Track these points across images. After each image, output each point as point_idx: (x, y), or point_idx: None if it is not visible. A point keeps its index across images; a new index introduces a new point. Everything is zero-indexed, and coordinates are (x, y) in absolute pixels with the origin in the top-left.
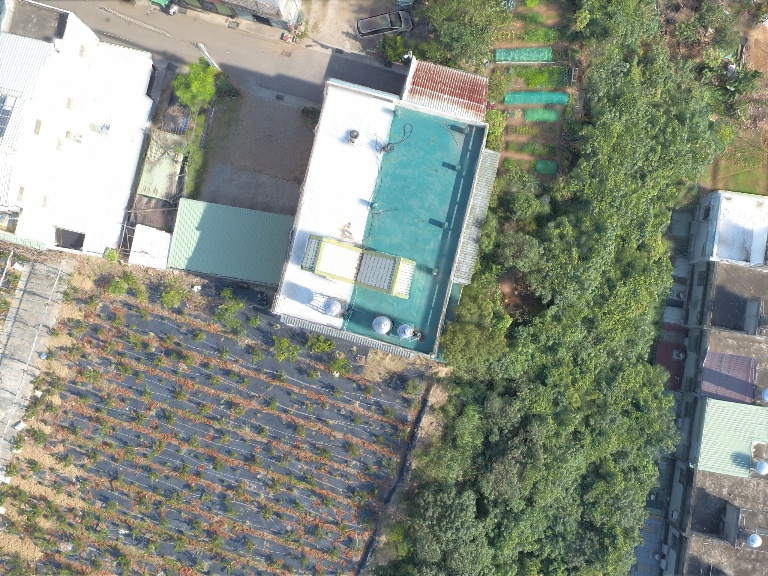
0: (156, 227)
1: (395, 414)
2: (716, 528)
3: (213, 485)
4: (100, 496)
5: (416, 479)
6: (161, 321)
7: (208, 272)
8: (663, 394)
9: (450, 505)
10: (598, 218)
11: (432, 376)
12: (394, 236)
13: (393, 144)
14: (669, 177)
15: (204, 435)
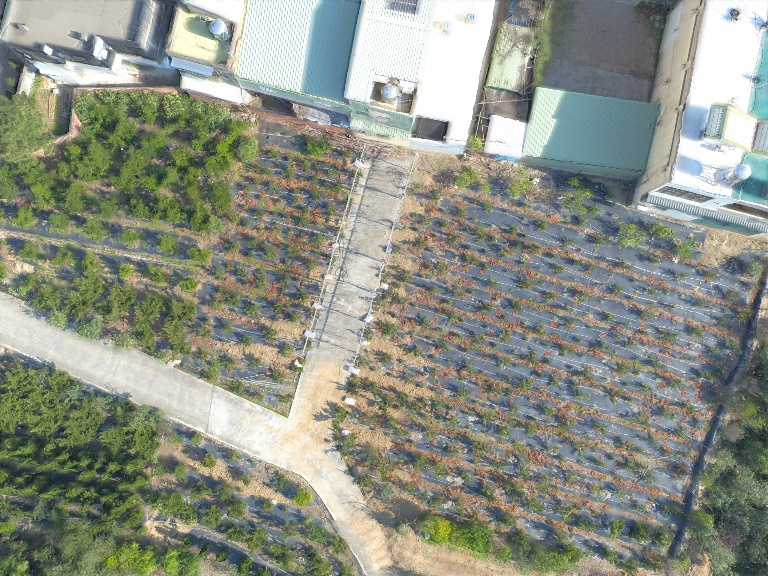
0: None
1: None
2: None
3: (558, 371)
4: (448, 385)
5: (756, 360)
6: (502, 213)
7: (563, 159)
8: None
9: None
10: None
11: None
12: None
13: None
14: None
15: (549, 323)
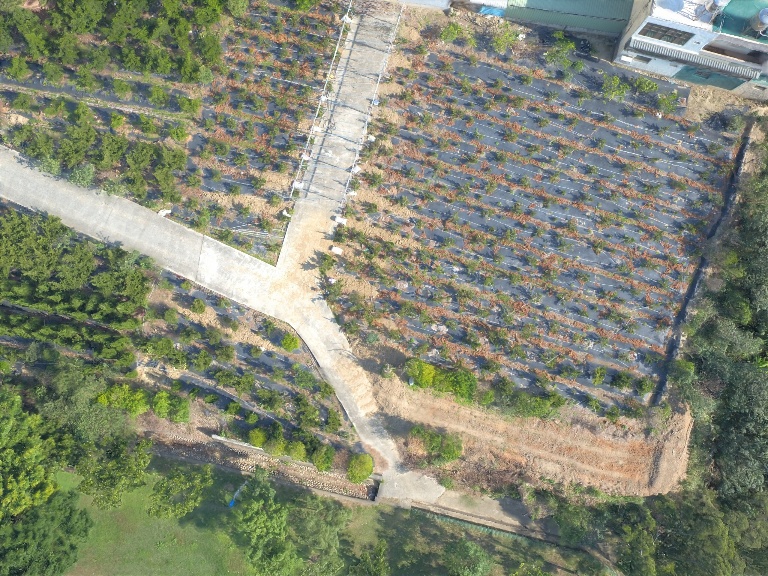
0: None
1: (717, 152)
2: None
3: (543, 224)
4: (434, 236)
5: (738, 214)
6: (489, 68)
7: (548, 9)
8: None
9: None
10: None
11: (751, 116)
12: None
13: None
14: None
15: (534, 175)
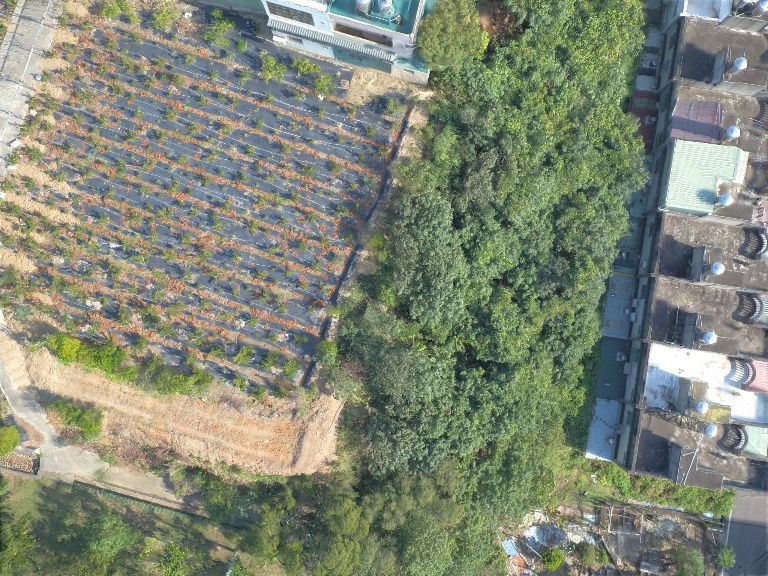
0: None
1: (377, 135)
2: (683, 273)
3: (201, 202)
4: (92, 212)
5: (396, 197)
6: (153, 45)
7: None
8: (634, 137)
9: (428, 208)
10: None
11: (413, 100)
12: None
13: None
14: None
15: (193, 154)
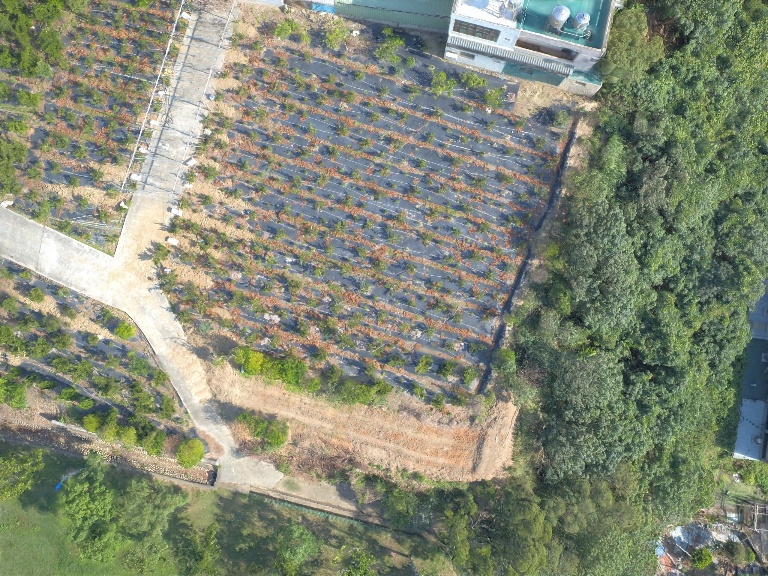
0: None
1: (545, 146)
2: None
3: (374, 216)
4: (268, 227)
5: (565, 207)
6: (323, 63)
7: (374, 6)
8: None
9: (605, 217)
10: None
11: (579, 111)
12: None
13: None
14: None
15: (365, 168)
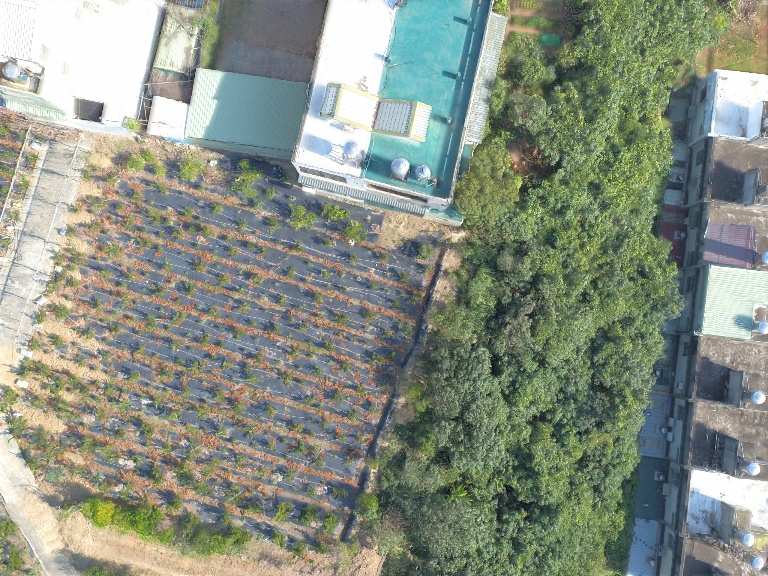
0: (173, 99)
1: (410, 280)
2: (720, 395)
3: (233, 354)
4: (122, 368)
5: (432, 342)
6: (178, 195)
7: (225, 140)
8: (667, 263)
9: (467, 360)
10: (602, 82)
11: (445, 242)
12: (409, 88)
13: (405, 0)
14: (667, 56)
15: (223, 305)
